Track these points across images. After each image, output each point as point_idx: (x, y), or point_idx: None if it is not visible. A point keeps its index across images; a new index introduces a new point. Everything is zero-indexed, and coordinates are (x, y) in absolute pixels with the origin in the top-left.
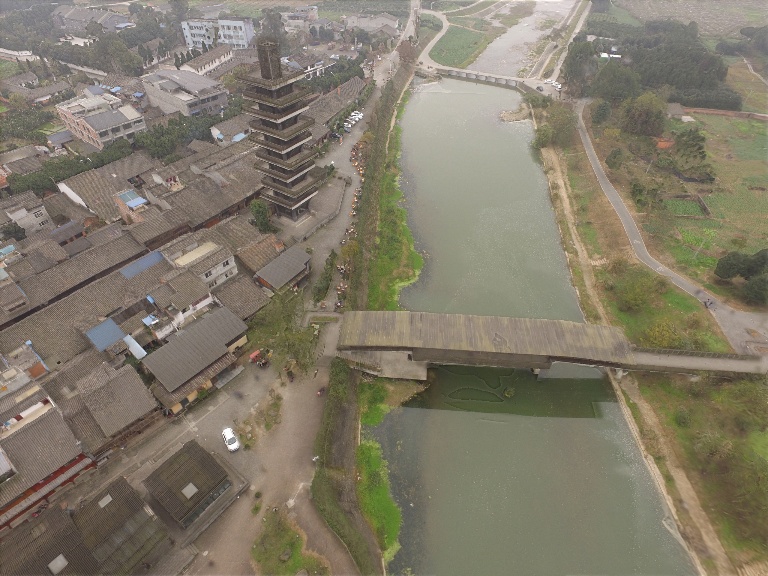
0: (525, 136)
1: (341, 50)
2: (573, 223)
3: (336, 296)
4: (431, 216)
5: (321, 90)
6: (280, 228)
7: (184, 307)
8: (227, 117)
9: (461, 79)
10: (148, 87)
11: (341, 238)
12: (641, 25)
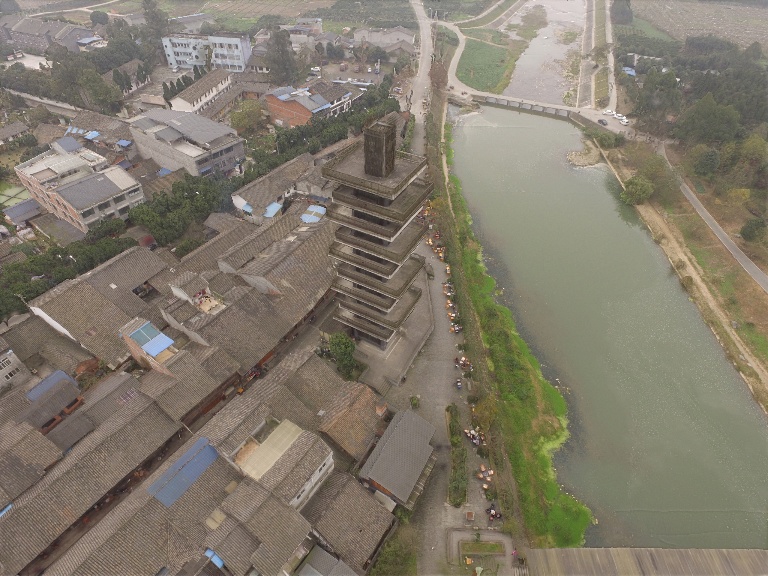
0: (609, 187)
1: (356, 72)
2: (729, 324)
3: (481, 492)
4: (544, 318)
5: (354, 130)
6: (366, 364)
7: (276, 573)
8: (250, 178)
9: (501, 107)
10: (137, 134)
11: (452, 374)
12: (672, 39)
